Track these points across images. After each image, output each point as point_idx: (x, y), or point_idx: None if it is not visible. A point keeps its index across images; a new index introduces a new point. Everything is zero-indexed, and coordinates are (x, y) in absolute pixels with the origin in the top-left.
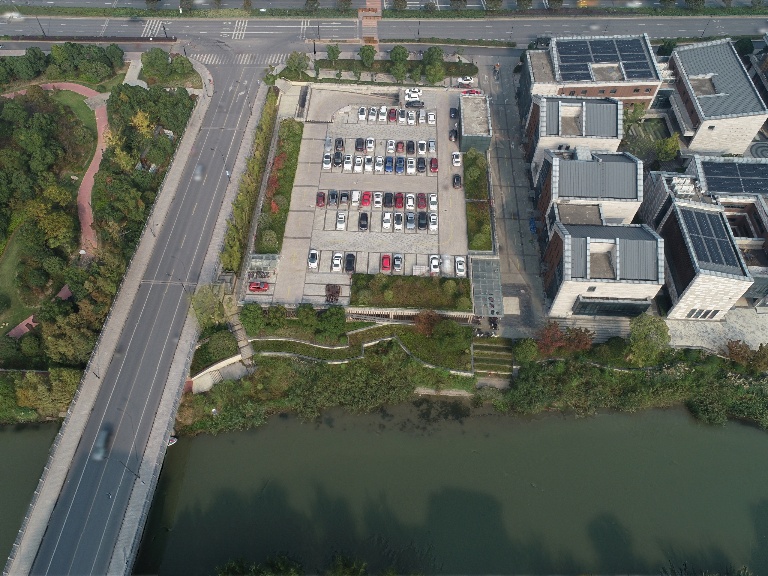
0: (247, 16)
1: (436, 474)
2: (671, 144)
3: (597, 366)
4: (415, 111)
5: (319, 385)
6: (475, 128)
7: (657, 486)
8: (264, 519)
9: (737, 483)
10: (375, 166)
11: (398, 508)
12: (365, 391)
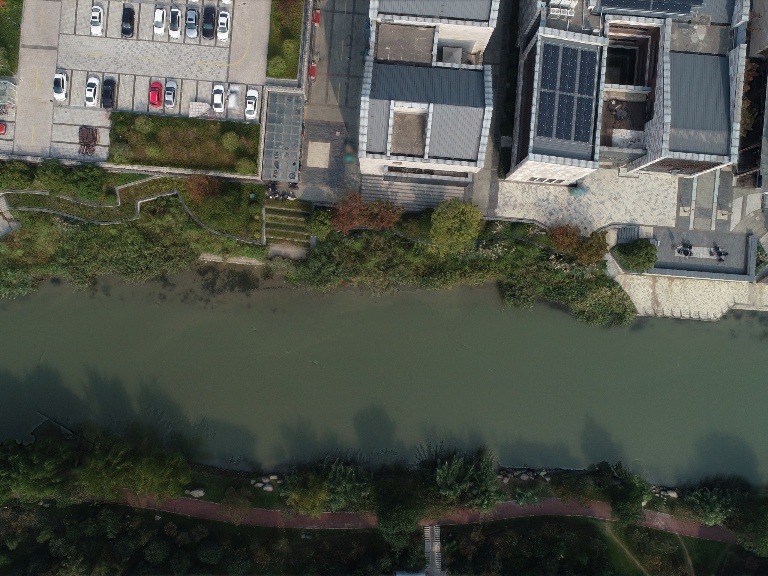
0: None
1: (216, 350)
2: None
3: (407, 238)
4: None
5: (86, 253)
6: None
7: (437, 371)
8: (43, 387)
9: (521, 369)
10: None
11: (175, 382)
12: (138, 262)
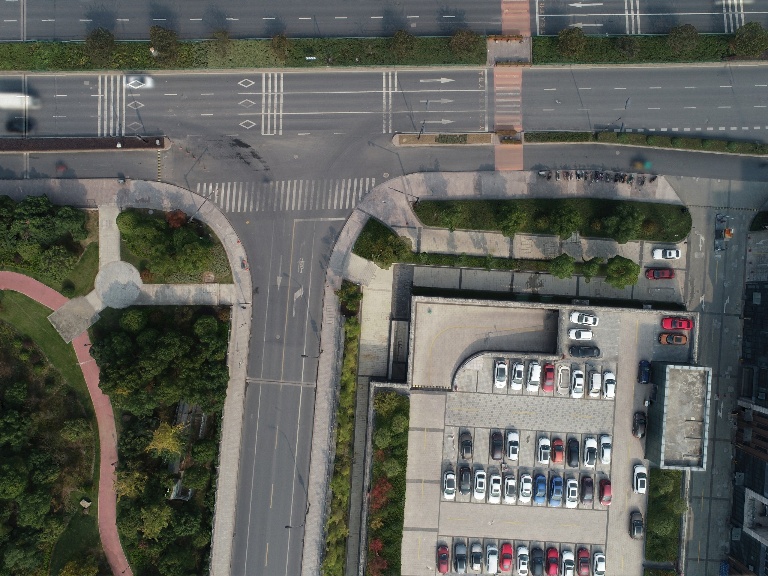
0: (281, 66)
1: None
2: None
3: None
4: (583, 363)
5: None
6: (681, 445)
7: None
8: None
9: None
10: (520, 496)
11: None
12: None
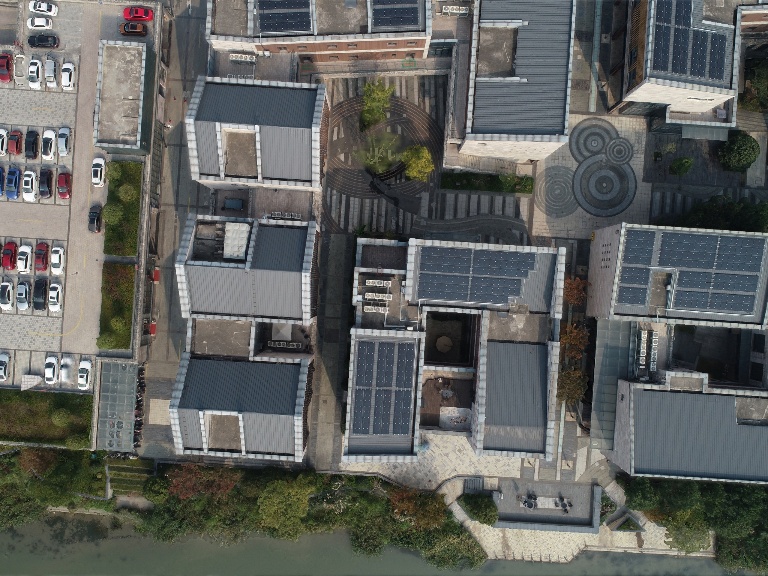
0: None
1: None
2: (413, 172)
3: None
4: (45, 55)
5: None
6: (118, 124)
7: None
8: None
9: None
10: None
11: None
12: None
